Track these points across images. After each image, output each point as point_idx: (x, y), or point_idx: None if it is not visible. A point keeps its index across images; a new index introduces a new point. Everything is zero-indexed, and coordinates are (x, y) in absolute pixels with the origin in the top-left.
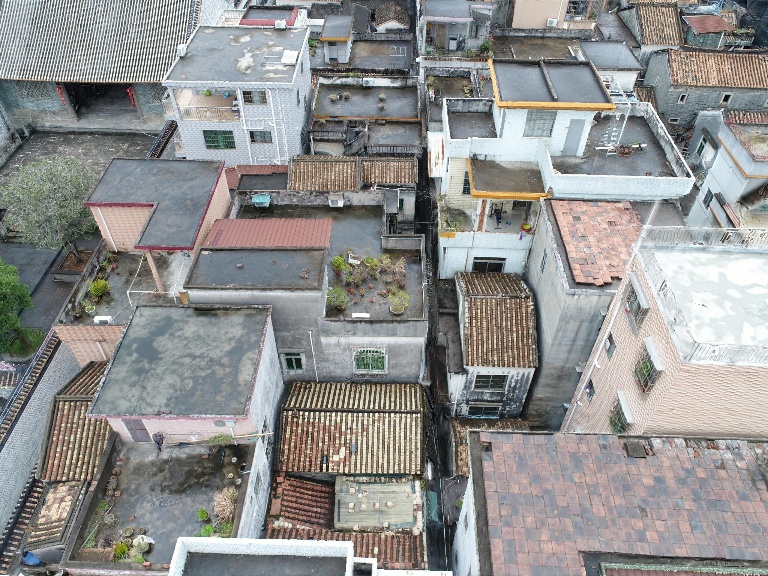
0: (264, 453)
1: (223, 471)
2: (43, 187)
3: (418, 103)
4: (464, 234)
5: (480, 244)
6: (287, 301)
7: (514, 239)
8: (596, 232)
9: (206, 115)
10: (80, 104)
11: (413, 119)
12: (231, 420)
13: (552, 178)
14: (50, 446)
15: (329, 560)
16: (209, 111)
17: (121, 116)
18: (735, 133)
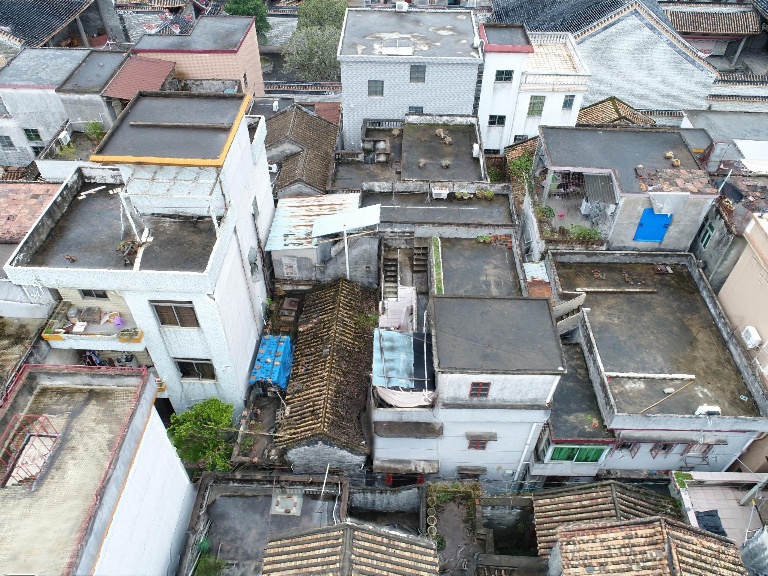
0: (28, 144)
1: None
2: (298, 33)
3: None
4: None
5: None
6: None
7: None
8: (6, 205)
9: None
10: None
11: None
12: None
13: None
14: None
15: None
16: None
17: None
18: (120, 382)
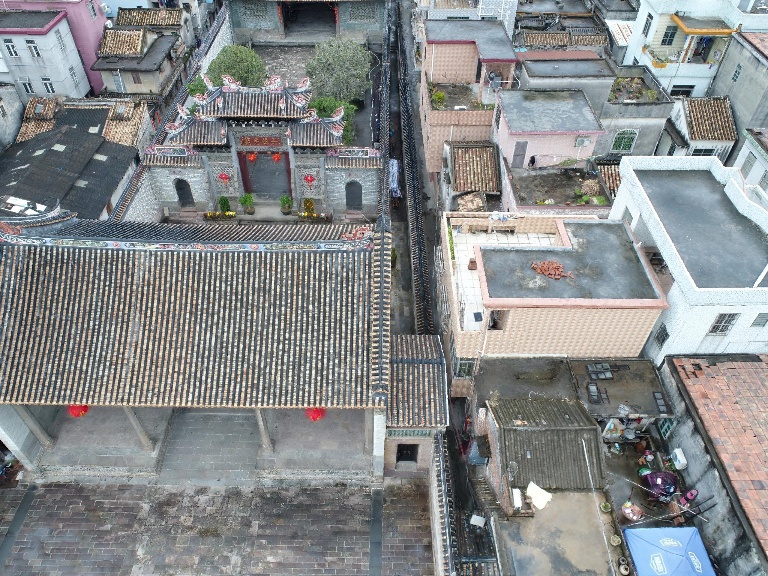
0: None
1: (574, 179)
2: (347, 53)
3: (591, 2)
4: (672, 65)
5: (681, 73)
6: (590, 88)
7: (705, 68)
8: None
9: (453, 4)
10: (284, 25)
11: (587, 14)
12: (589, 139)
13: (743, 17)
14: (456, 172)
15: (700, 171)
16: (456, 1)
17: (317, 34)
18: None
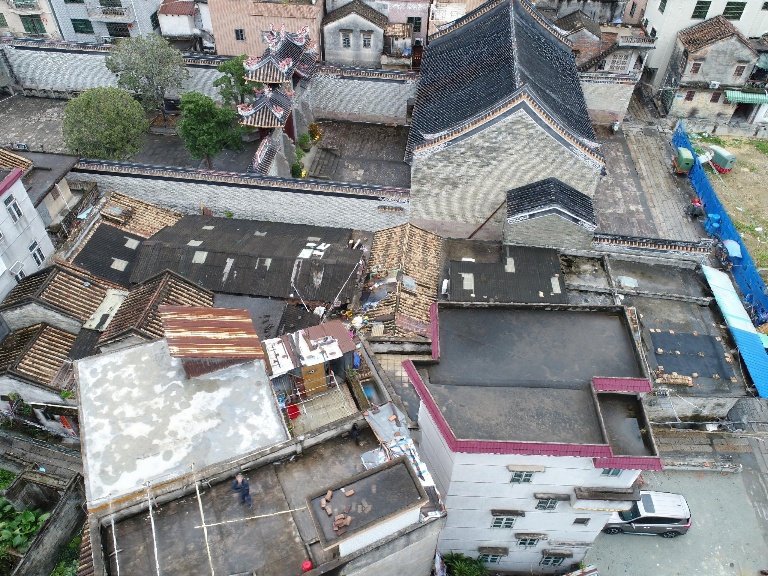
0: None
1: None
2: None
3: None
4: None
5: None
6: None
7: None
8: None
9: None
10: None
11: None
12: None
13: None
14: None
15: None
16: None
17: None
18: None
